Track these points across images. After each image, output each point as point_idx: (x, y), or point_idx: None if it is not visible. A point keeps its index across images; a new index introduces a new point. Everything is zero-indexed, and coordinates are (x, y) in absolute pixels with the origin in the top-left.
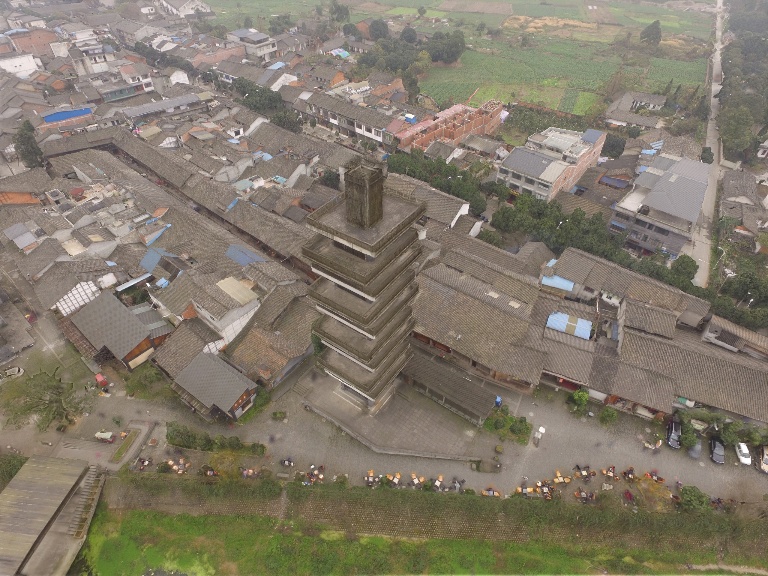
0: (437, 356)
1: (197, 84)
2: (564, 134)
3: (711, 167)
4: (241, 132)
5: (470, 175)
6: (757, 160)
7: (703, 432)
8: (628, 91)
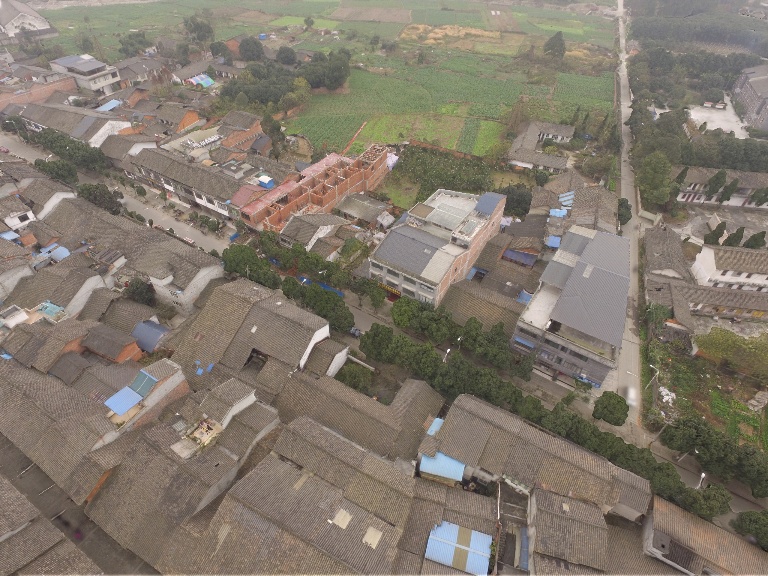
0: None
1: None
2: (456, 198)
3: (629, 220)
4: (30, 216)
5: (337, 267)
6: None
7: None
8: (533, 121)
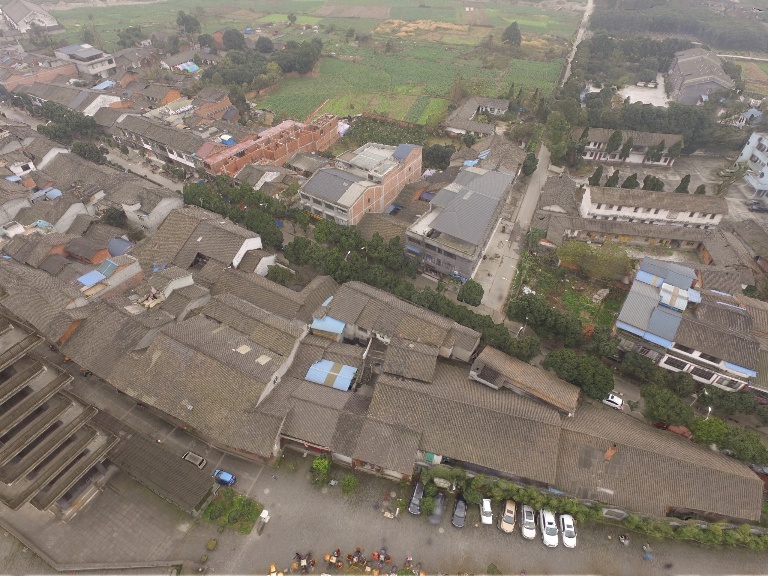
0: (179, 428)
1: (2, 111)
2: (382, 150)
3: (539, 173)
4: (31, 166)
5: (276, 201)
6: (586, 162)
7: (450, 490)
8: (473, 96)
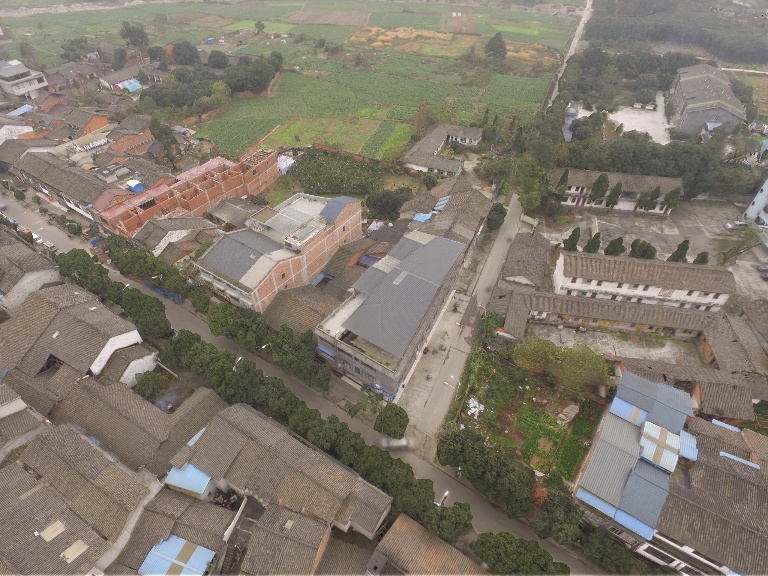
0: None
1: None
2: (314, 202)
3: (509, 225)
4: None
5: (175, 272)
6: (566, 210)
7: None
8: (442, 124)
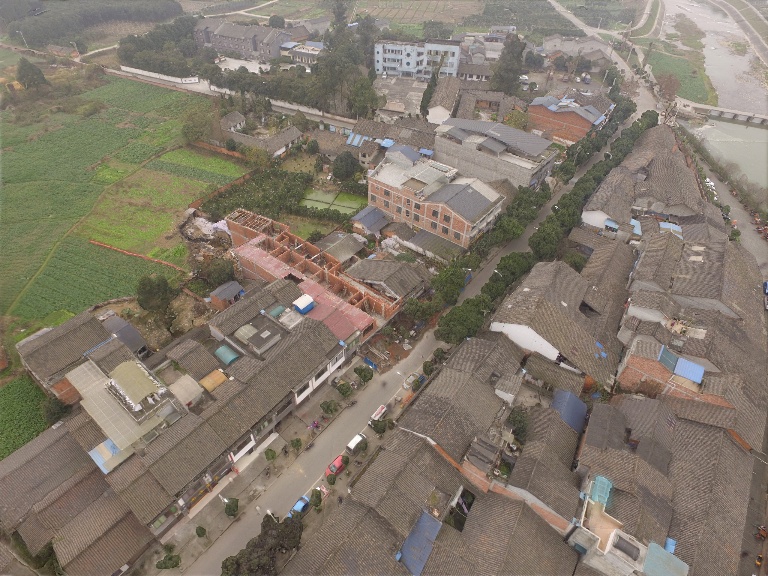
0: None
1: None
2: (379, 173)
3: None
4: None
5: None
6: None
7: None
8: None
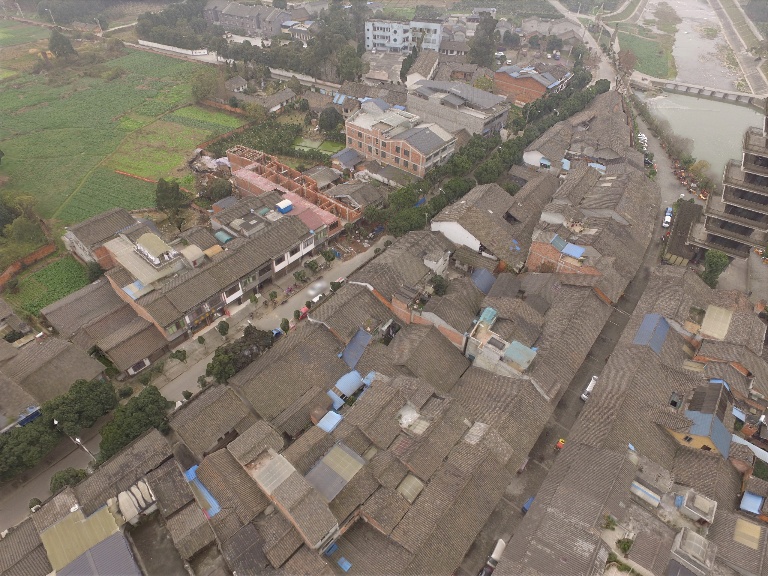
0: None
1: None
2: (355, 120)
3: None
4: None
5: None
6: None
7: None
8: None
